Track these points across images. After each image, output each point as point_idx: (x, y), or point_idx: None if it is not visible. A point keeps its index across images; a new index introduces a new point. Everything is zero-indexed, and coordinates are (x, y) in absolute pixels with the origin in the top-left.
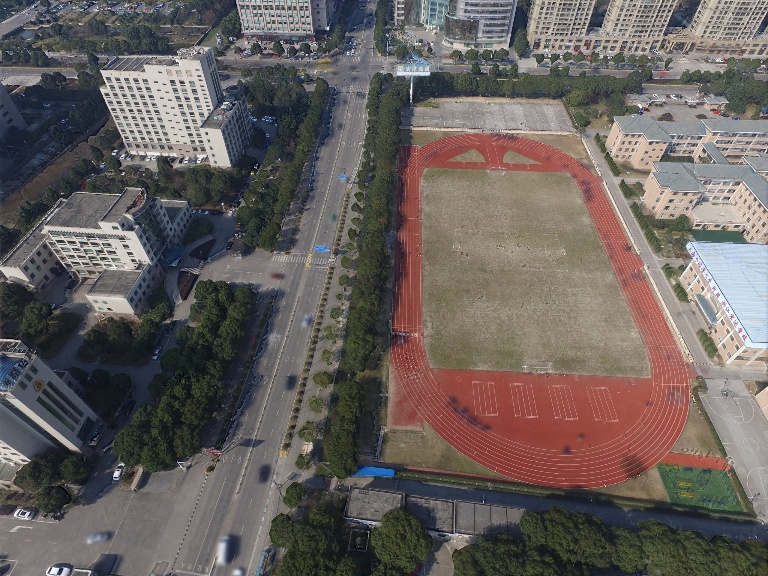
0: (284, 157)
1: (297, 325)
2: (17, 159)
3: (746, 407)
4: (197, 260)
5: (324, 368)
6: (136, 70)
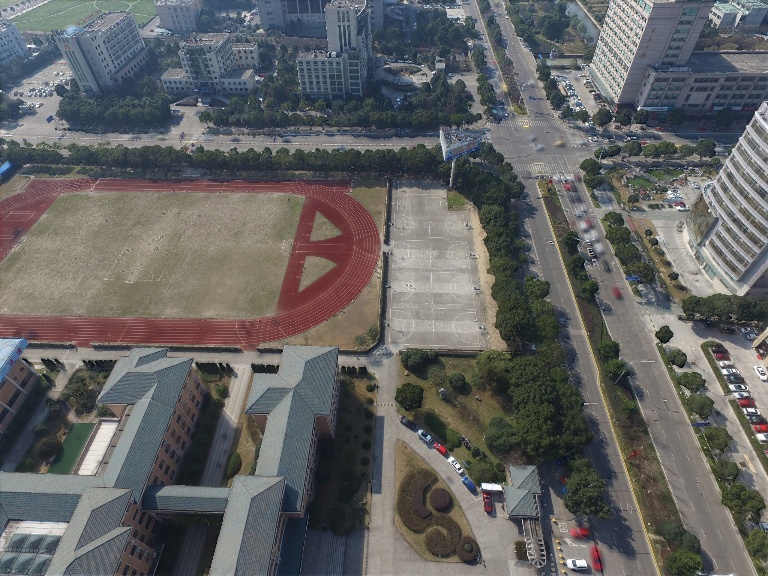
0: None
1: (132, 143)
2: None
3: None
4: None
5: None
6: None
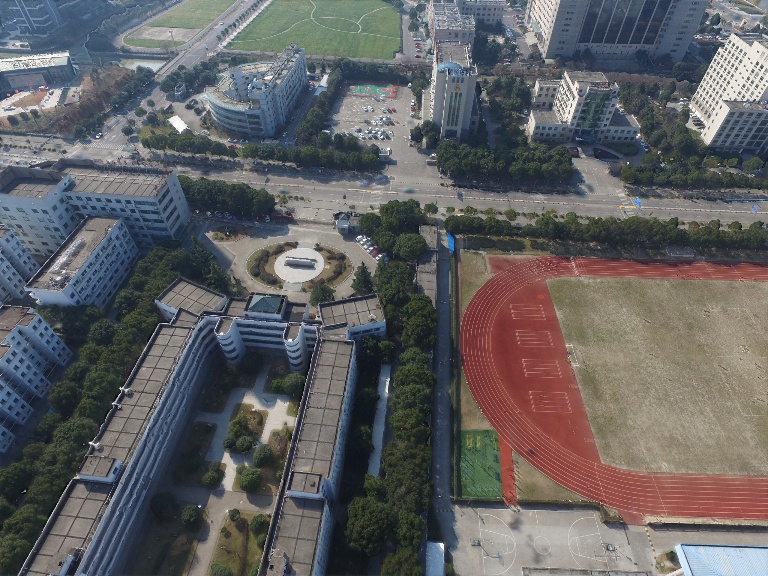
0: (762, 179)
1: (556, 206)
2: (641, 69)
3: (597, 568)
4: (592, 153)
5: (524, 222)
6: (751, 45)
